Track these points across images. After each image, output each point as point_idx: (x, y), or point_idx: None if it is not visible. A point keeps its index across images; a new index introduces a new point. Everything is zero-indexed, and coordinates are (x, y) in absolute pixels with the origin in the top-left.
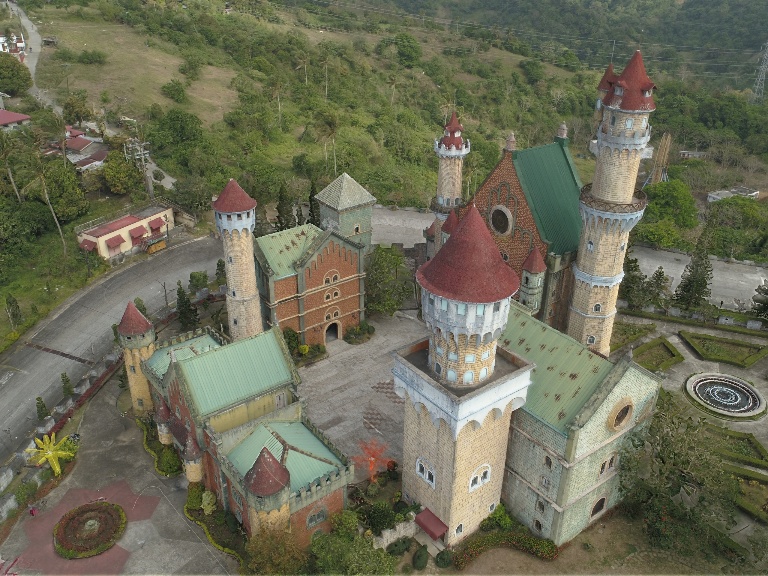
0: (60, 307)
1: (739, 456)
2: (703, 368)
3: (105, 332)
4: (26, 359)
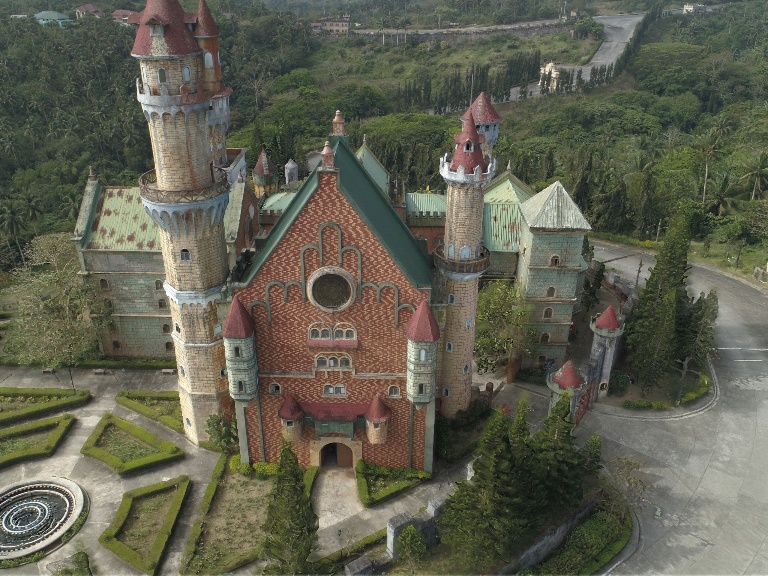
0: (690, 260)
1: (4, 431)
2: None
3: (629, 273)
4: (619, 252)
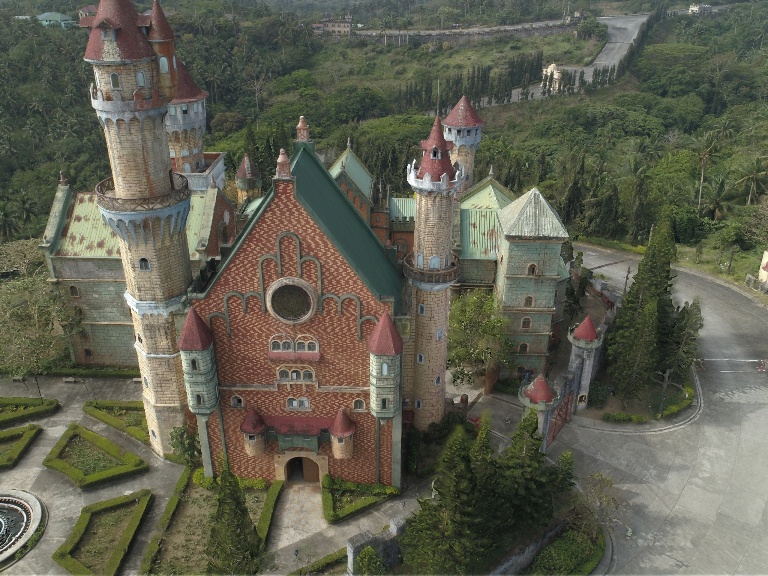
0: (682, 266)
1: None
2: (20, 574)
3: (619, 279)
4: (610, 258)
